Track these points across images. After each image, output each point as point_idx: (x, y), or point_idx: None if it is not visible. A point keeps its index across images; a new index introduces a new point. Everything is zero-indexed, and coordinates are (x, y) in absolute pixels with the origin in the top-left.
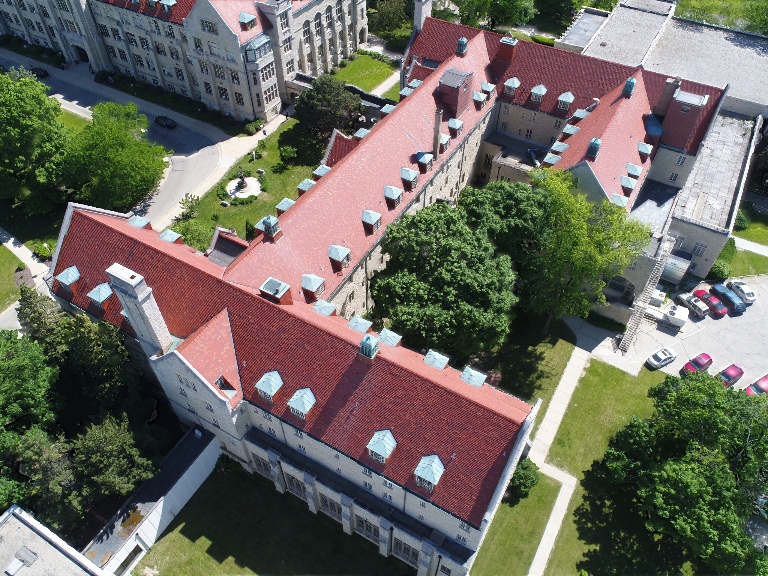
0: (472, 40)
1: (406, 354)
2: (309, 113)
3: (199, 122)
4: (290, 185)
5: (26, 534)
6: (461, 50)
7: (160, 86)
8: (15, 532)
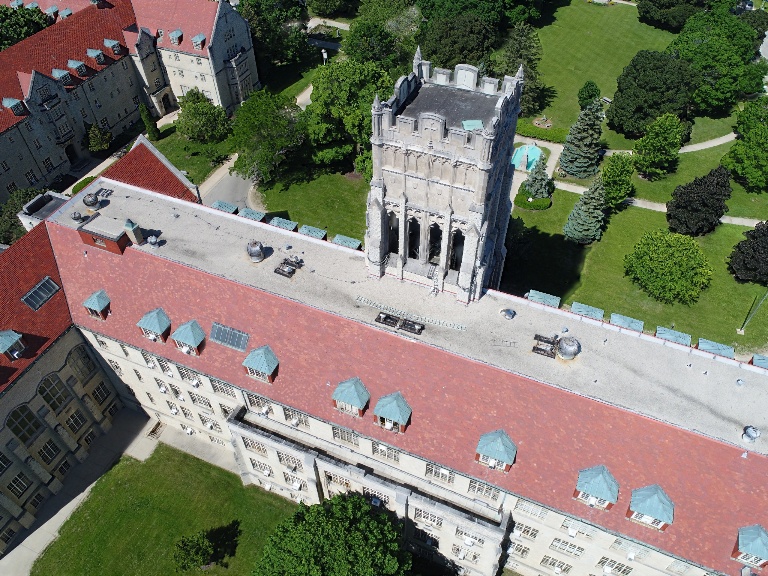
0: None
1: (45, 4)
2: None
3: None
4: None
5: (231, 2)
6: None
7: None
8: None
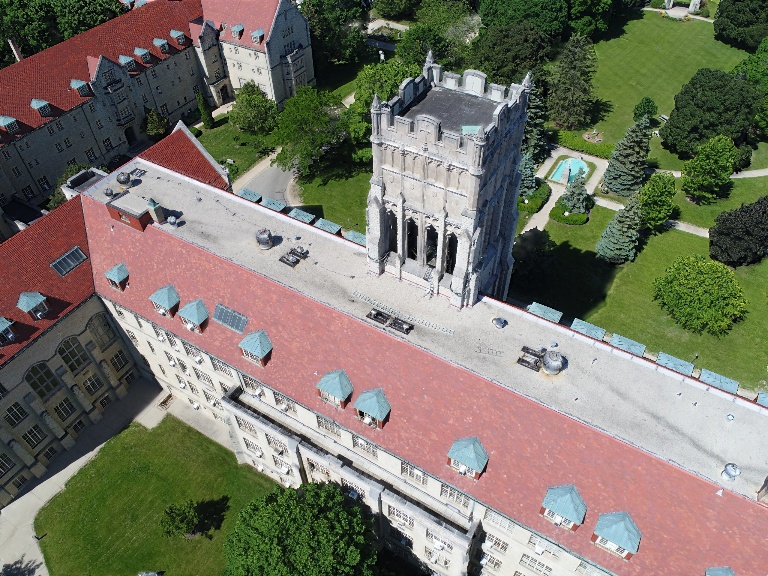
0: None
1: None
2: None
3: None
4: None
5: (297, 0)
6: None
7: None
8: (302, 0)
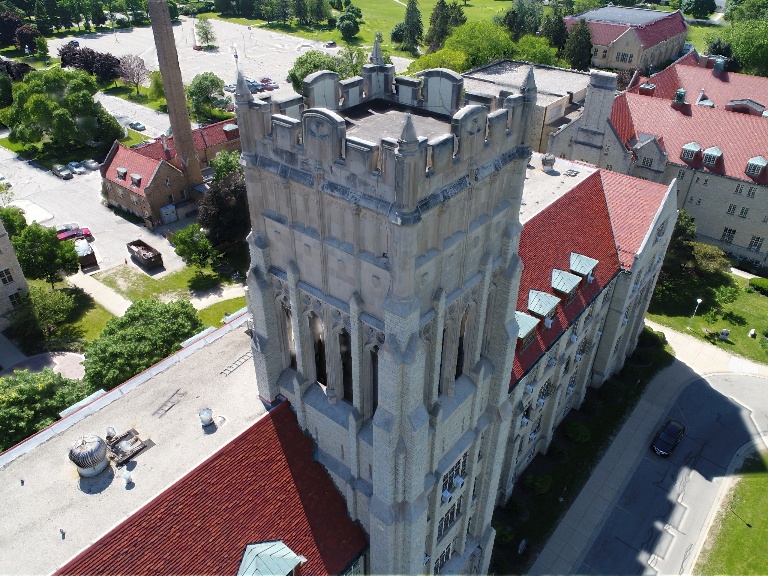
0: (651, 97)
1: None
2: (689, 247)
3: (647, 396)
4: (764, 313)
5: None
6: (683, 100)
7: (552, 445)
8: None
